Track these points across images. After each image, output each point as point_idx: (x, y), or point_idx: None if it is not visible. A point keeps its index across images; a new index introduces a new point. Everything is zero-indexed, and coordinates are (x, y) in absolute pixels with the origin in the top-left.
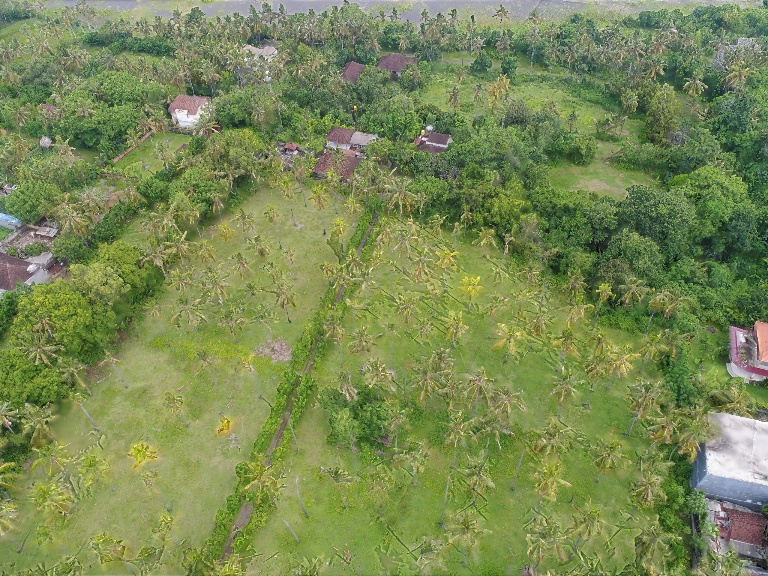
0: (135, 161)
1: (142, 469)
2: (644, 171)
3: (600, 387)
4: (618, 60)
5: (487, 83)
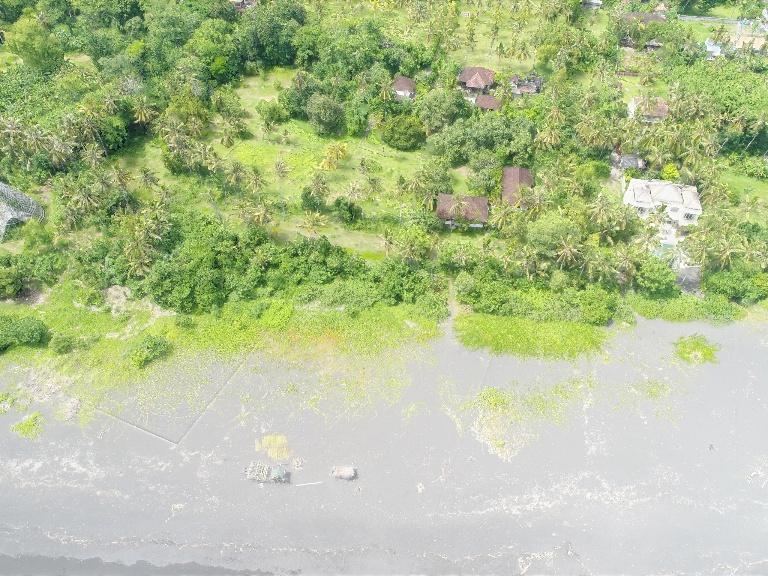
0: (652, 86)
1: None
2: None
3: None
4: None
5: None
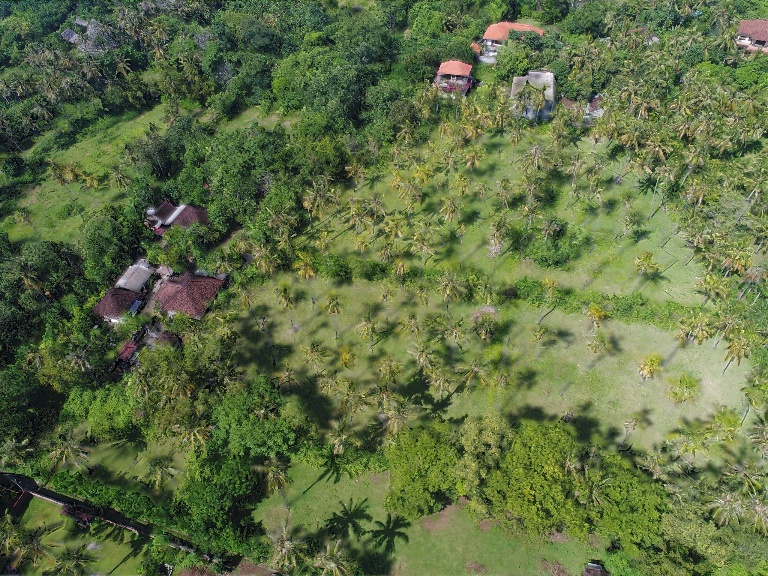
0: None
1: (641, 397)
2: (234, 114)
3: (483, 145)
4: (84, 83)
5: (24, 193)
